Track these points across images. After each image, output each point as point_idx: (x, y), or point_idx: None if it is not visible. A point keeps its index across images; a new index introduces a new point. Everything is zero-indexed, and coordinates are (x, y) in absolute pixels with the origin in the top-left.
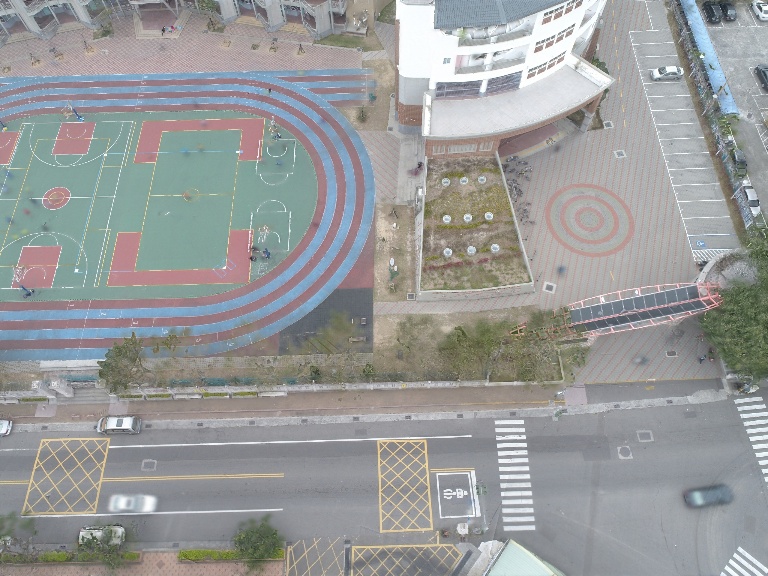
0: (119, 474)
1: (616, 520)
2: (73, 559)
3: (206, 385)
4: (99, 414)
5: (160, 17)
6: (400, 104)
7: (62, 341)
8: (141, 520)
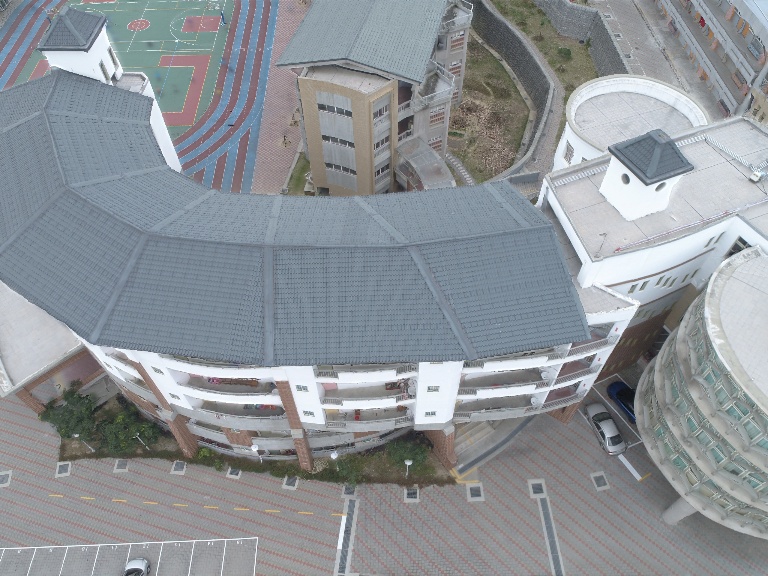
0: None
1: None
2: None
3: None
4: None
5: None
6: None
7: (2, 47)
8: None
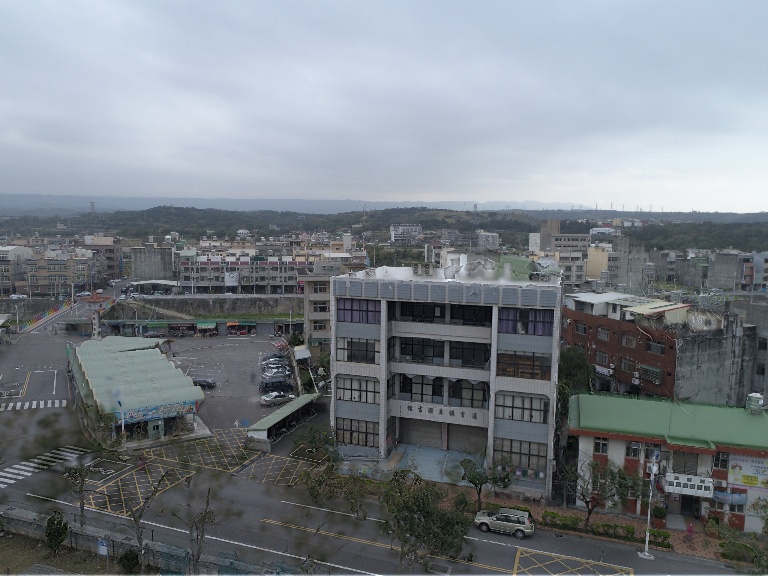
0: (487, 571)
1: (2, 435)
2: None
3: None
4: None
5: None
6: None
7: None
8: None
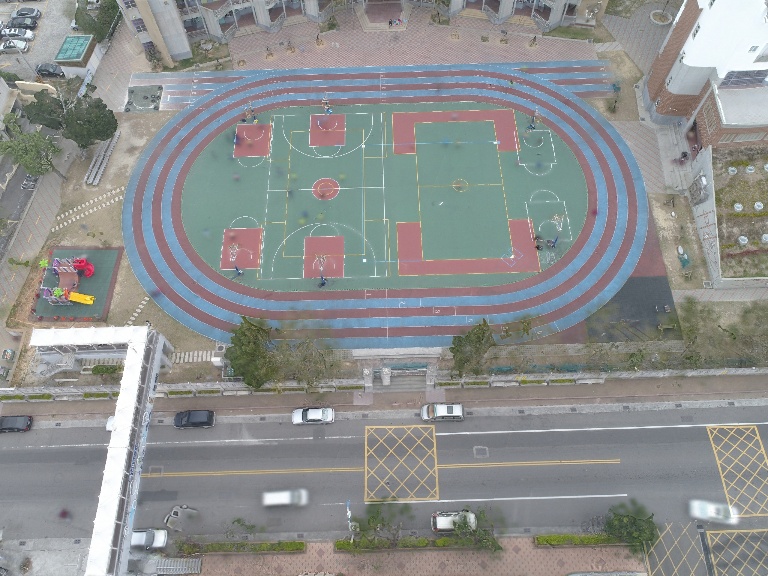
0: (453, 461)
1: None
2: (428, 545)
3: (529, 372)
4: (417, 402)
5: (384, 10)
6: (669, 94)
7: (369, 330)
8: (486, 506)
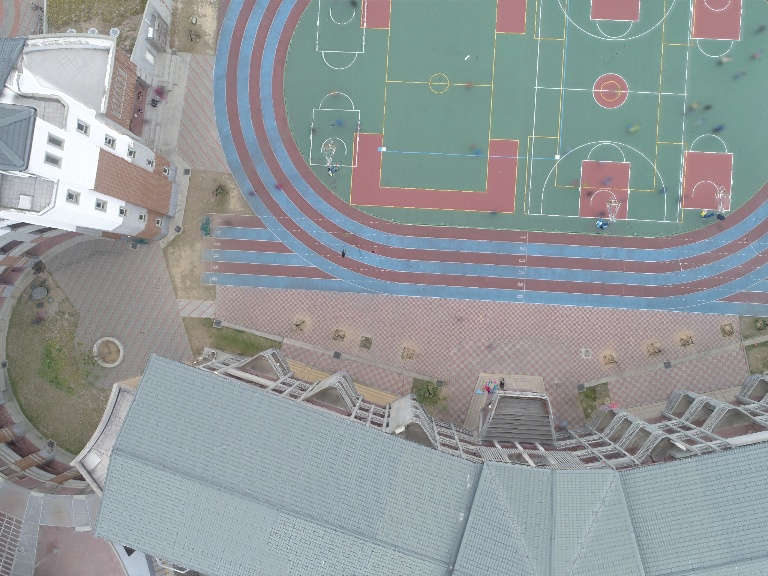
0: None
1: None
2: None
3: None
4: None
5: None
6: (155, 153)
7: None
8: None
